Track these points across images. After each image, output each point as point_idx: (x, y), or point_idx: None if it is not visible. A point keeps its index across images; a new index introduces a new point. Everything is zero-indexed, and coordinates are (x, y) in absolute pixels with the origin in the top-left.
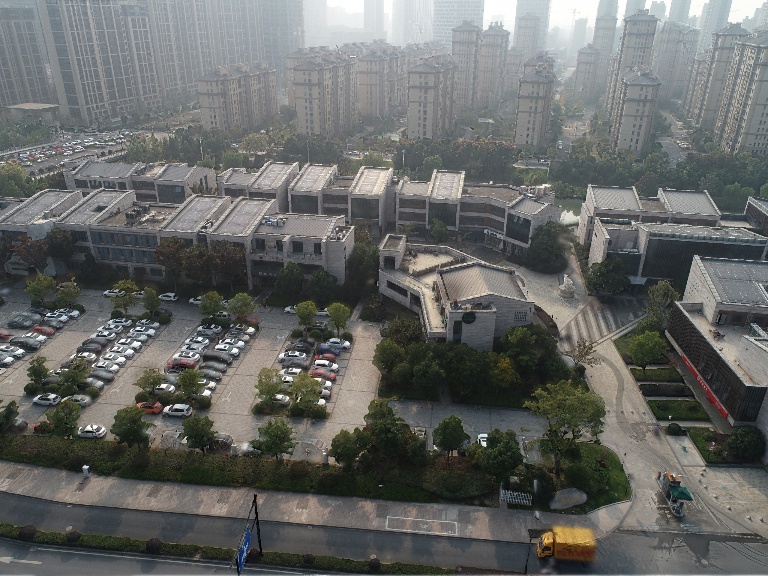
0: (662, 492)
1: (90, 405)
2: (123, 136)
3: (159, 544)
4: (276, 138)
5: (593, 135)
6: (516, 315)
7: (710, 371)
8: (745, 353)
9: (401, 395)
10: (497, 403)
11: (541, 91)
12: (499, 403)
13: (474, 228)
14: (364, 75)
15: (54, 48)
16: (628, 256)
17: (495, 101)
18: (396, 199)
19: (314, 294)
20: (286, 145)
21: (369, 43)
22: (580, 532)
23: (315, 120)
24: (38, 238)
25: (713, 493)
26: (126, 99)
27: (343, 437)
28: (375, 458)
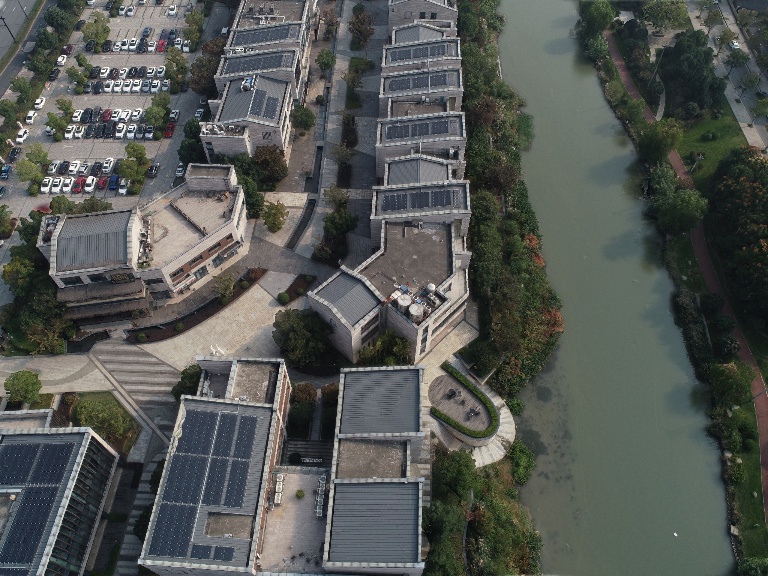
0: None
1: (71, 94)
2: None
3: None
4: None
5: None
6: None
7: None
8: None
9: None
10: None
11: None
12: None
13: None
14: None
15: None
16: None
17: None
18: None
19: None
20: None
21: None
22: None
23: None
24: None
25: None
26: None
27: None
28: None
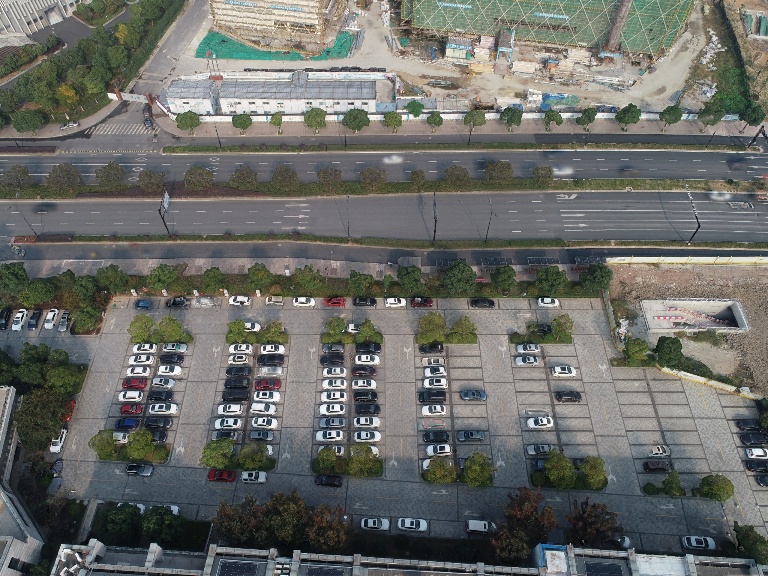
0: None
1: None
2: None
3: None
4: None
5: None
6: None
7: None
8: None
9: None
10: None
11: None
12: None
13: None
14: None
15: None
16: None
17: None
18: None
19: None
20: None
21: None
22: None
23: None
24: None
25: None
26: None
27: None
28: None
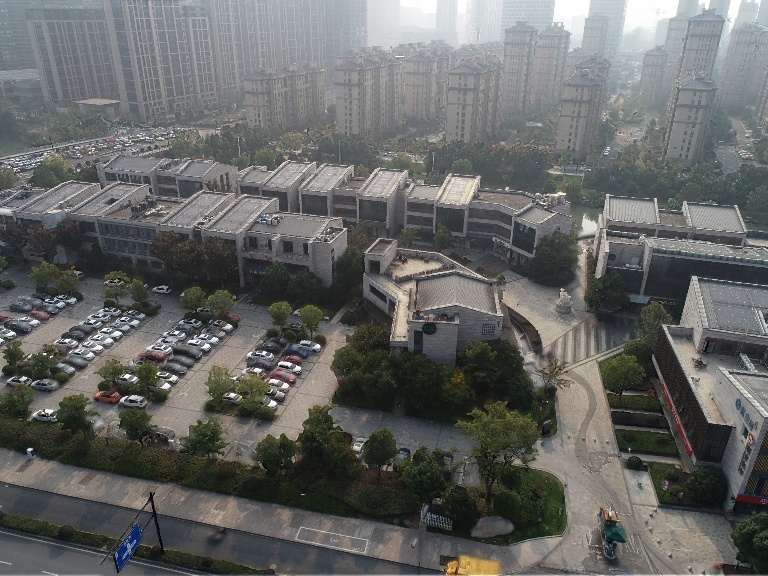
0: (600, 530)
1: (57, 390)
2: (173, 132)
3: (71, 531)
4: (314, 137)
5: (645, 142)
6: (484, 329)
7: (682, 403)
8: (718, 386)
9: (354, 403)
10: (450, 419)
11: (585, 95)
12: (452, 419)
13: (482, 235)
14: (411, 76)
15: (117, 47)
16: (629, 272)
17: (547, 104)
18: (405, 202)
19: (296, 295)
20: (321, 144)
21: (426, 44)
22: (495, 564)
23: (354, 120)
24: (51, 227)
25: (657, 537)
26: (183, 96)
27: (267, 442)
28: (303, 466)
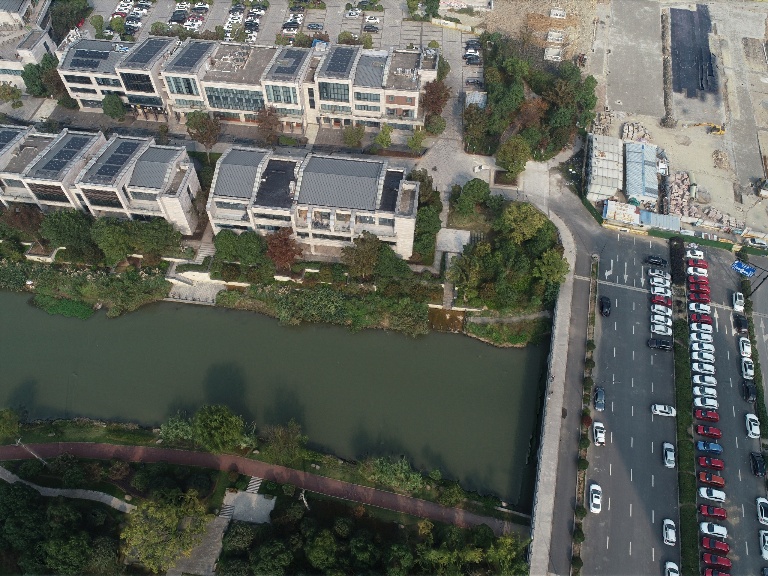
0: None
1: None
2: None
3: None
4: None
5: None
6: None
7: None
8: None
9: None
10: None
11: None
12: None
13: None
14: None
15: None
16: None
17: None
18: None
19: None
20: None
21: None
22: None
23: None
24: None
25: None
26: None
27: None
28: None
